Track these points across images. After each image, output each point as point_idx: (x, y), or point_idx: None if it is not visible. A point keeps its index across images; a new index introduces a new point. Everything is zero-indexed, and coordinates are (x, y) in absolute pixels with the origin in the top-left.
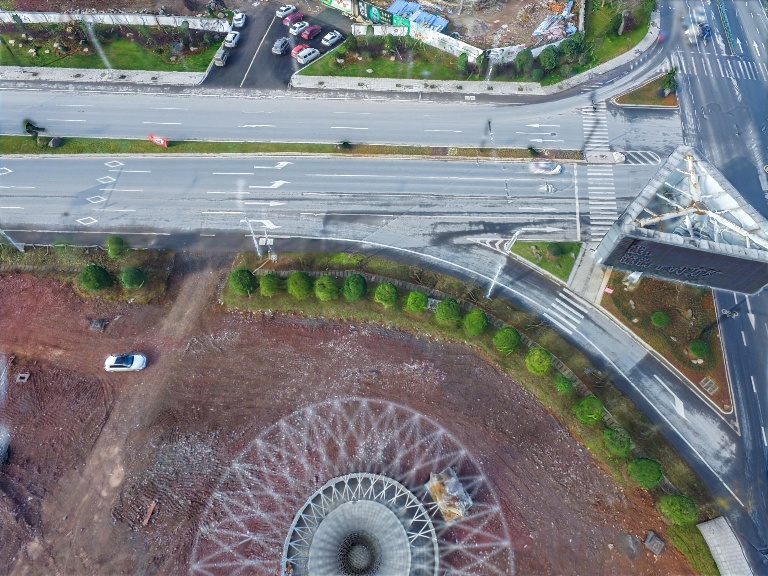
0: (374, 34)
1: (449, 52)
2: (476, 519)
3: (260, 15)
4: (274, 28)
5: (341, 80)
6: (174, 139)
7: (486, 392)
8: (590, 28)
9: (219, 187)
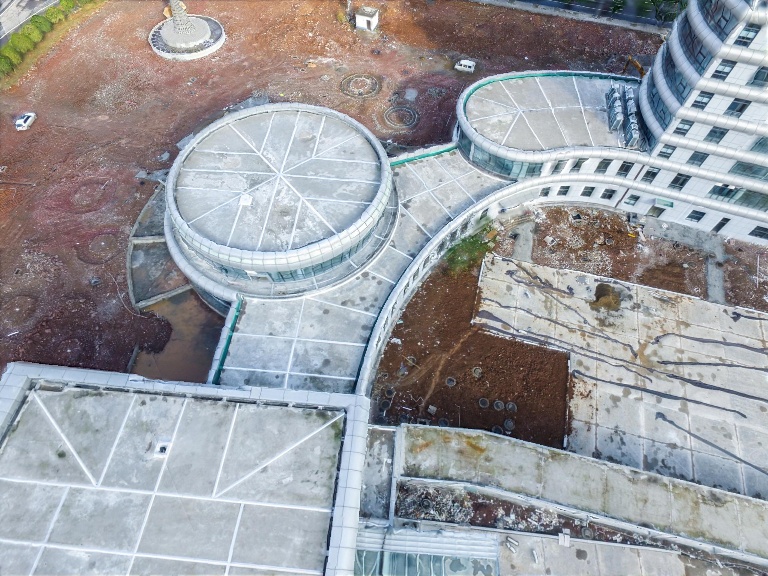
0: None
1: None
2: (191, 10)
3: None
4: None
5: None
6: None
7: (137, 1)
8: None
9: None
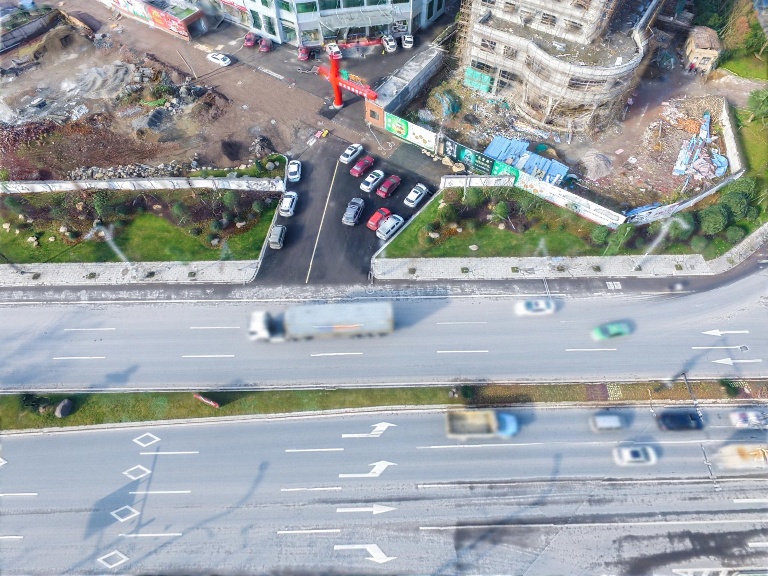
0: (469, 185)
1: (572, 210)
2: None
3: (318, 160)
4: (339, 180)
5: (438, 264)
6: (226, 386)
7: None
8: (743, 157)
9: (297, 479)
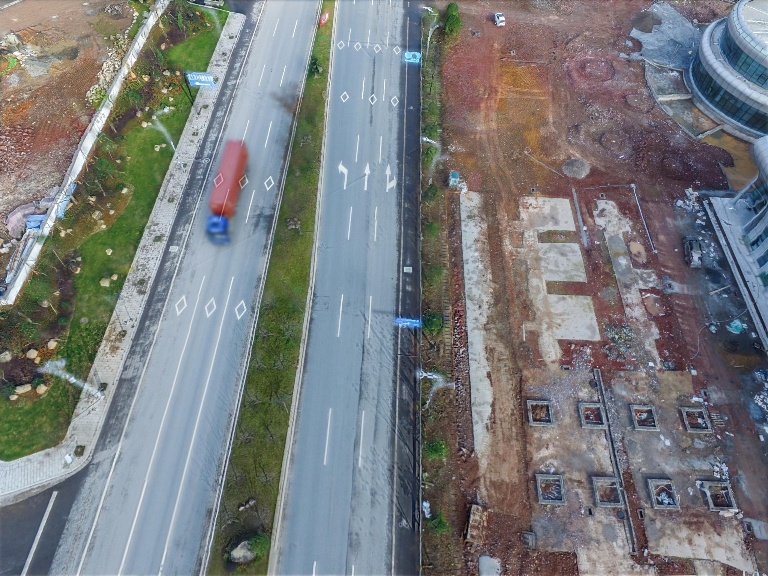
0: None
1: None
2: None
3: None
4: None
5: None
6: (316, 21)
7: None
8: None
9: (368, 1)
